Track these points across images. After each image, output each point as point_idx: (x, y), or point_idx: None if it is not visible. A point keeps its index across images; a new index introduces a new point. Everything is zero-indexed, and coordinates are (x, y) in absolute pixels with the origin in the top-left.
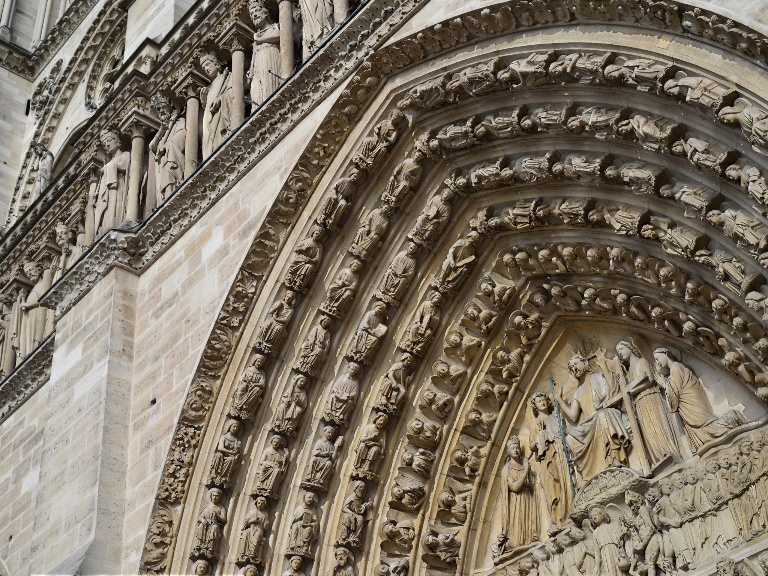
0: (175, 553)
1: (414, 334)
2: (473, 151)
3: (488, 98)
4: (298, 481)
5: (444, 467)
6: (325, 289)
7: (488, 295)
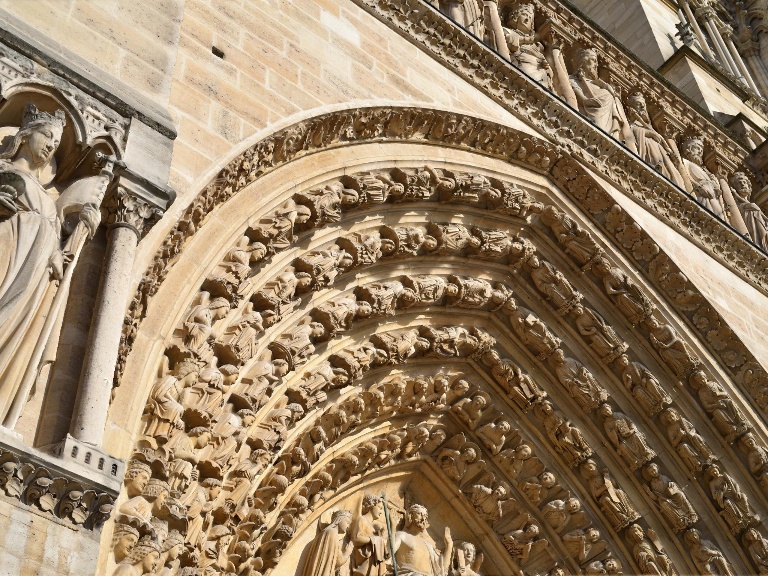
0: (189, 247)
1: (406, 349)
2: (539, 301)
3: (605, 303)
4: (273, 335)
5: (310, 472)
6: (400, 220)
7: (436, 389)
